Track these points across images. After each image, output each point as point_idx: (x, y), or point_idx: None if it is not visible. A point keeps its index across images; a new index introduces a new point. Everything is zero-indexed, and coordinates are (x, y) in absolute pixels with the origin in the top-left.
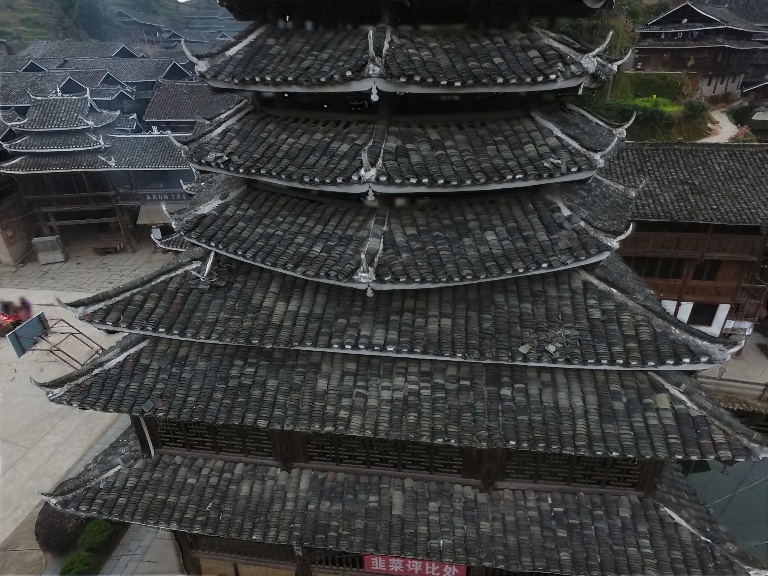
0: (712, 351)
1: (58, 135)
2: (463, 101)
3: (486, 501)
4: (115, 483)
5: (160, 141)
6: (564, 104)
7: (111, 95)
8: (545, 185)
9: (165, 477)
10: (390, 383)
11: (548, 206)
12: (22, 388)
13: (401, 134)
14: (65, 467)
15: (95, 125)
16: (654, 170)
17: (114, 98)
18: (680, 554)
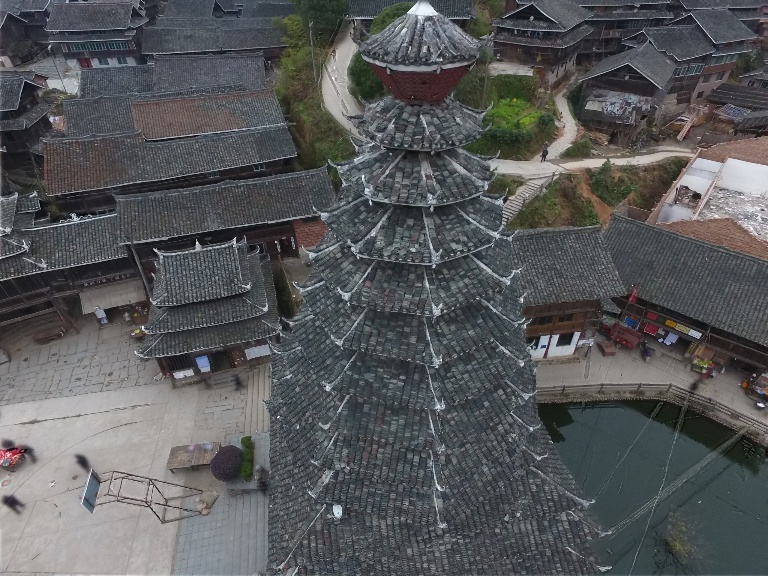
0: (583, 503)
1: None
2: None
3: (487, 567)
4: None
5: (83, 228)
6: None
7: None
8: None
9: None
10: (443, 541)
11: None
12: (76, 521)
13: None
14: None
15: (10, 228)
16: (532, 259)
17: None
18: (573, 567)
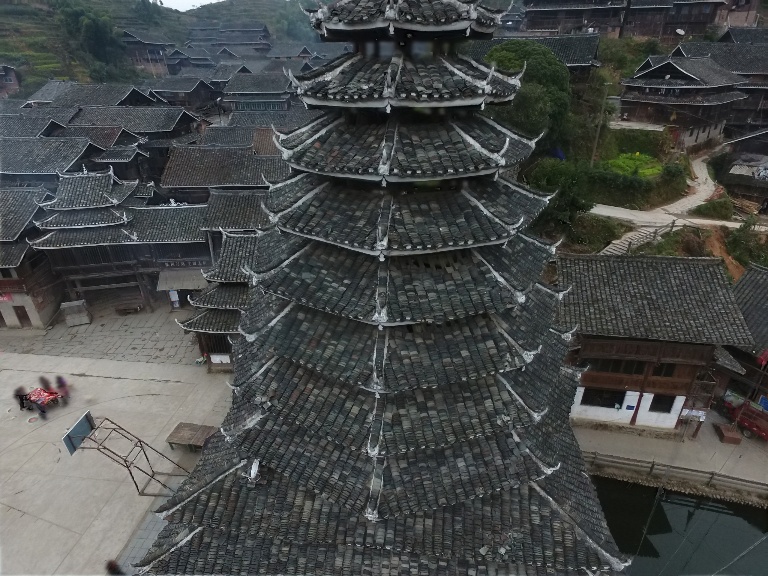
0: (612, 562)
1: (85, 211)
2: None
3: None
4: None
5: (177, 213)
6: None
7: (128, 157)
8: None
9: None
10: (388, 562)
11: None
12: (68, 470)
13: (396, 398)
14: (114, 554)
15: (118, 202)
16: (618, 283)
17: (131, 160)
18: None
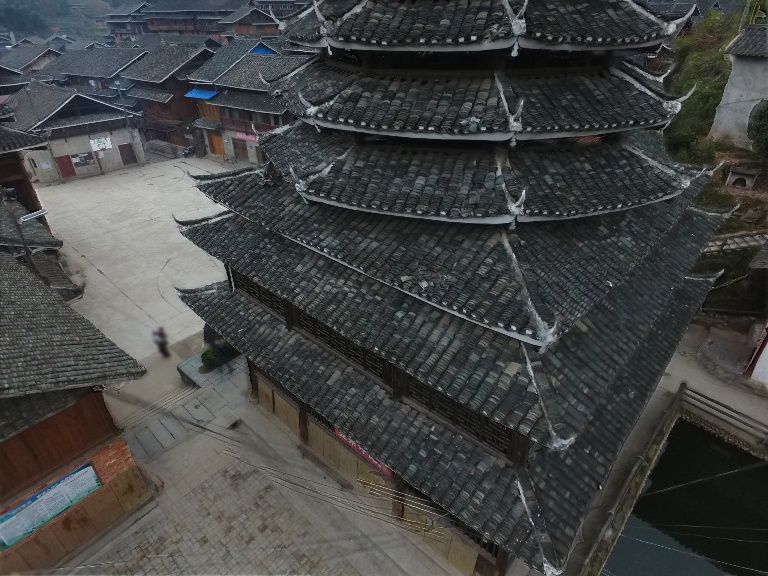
0: (540, 328)
1: None
2: (412, 58)
3: (388, 405)
4: (209, 298)
5: None
6: (608, 68)
7: None
8: (471, 142)
9: (231, 305)
10: (335, 281)
11: (491, 165)
12: None
13: (368, 84)
14: None
15: None
16: None
17: None
18: (501, 519)
